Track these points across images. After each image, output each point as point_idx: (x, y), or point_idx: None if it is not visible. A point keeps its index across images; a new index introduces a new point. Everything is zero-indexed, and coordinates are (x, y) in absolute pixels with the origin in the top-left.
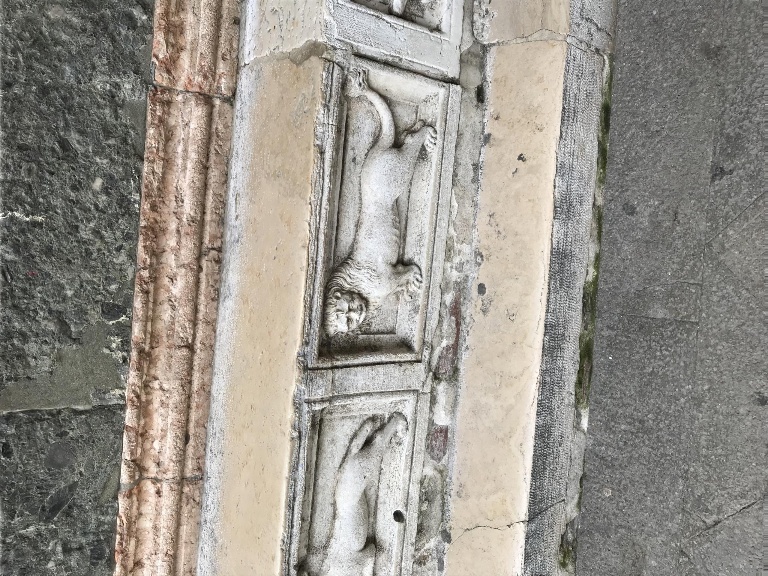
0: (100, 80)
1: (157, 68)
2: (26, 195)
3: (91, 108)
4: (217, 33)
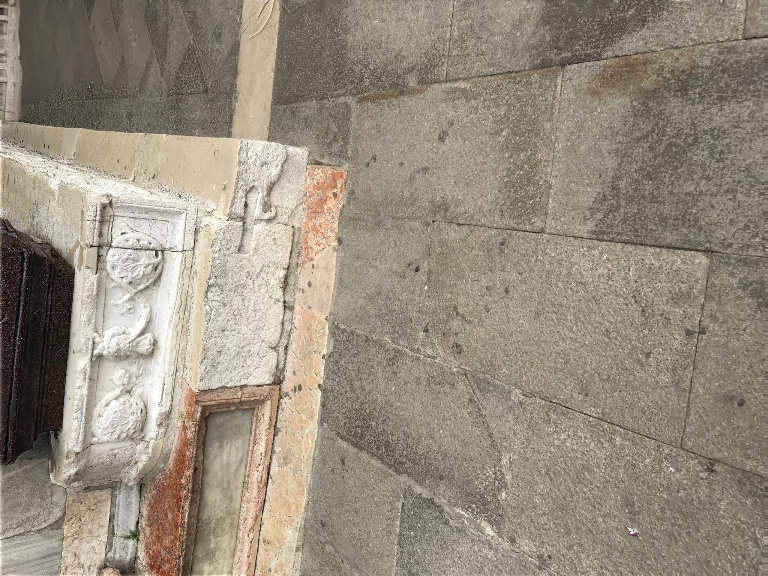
0: None
1: None
2: None
3: None
4: None
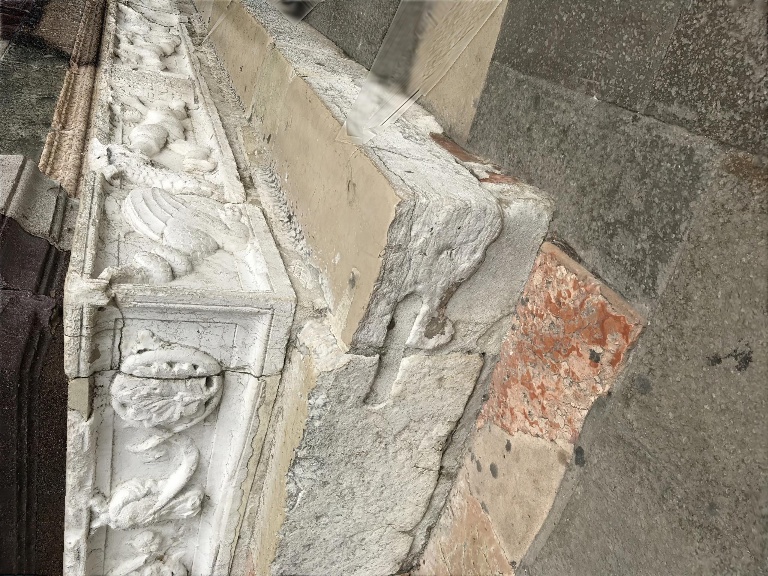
0: (70, 4)
1: (87, 5)
2: (48, 7)
3: (68, 5)
4: (105, 2)
